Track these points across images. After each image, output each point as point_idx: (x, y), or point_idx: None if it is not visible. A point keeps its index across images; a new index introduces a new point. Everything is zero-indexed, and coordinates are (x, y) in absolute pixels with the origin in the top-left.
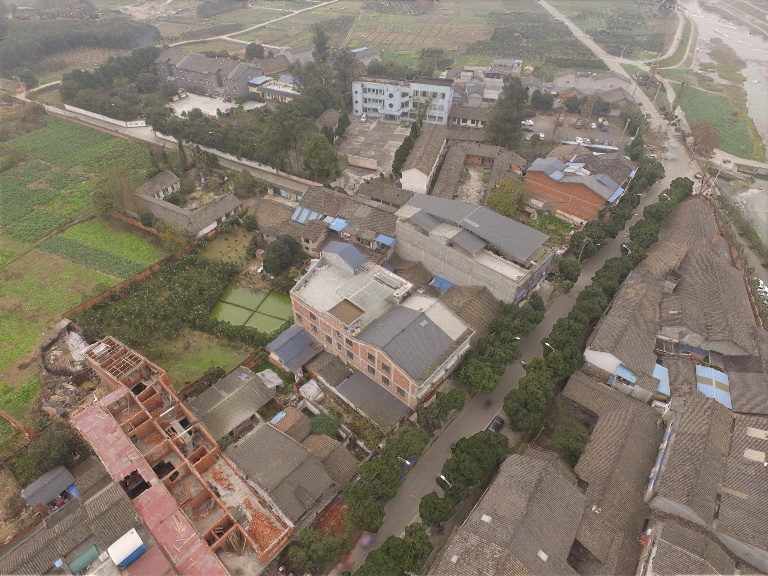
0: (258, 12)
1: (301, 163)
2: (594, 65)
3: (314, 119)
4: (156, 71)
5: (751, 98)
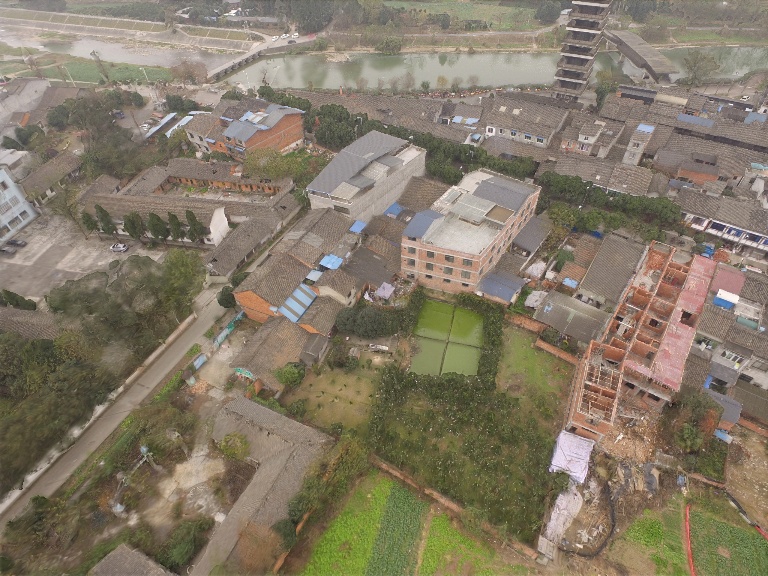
0: None
1: None
2: None
3: None
4: None
5: (78, 55)
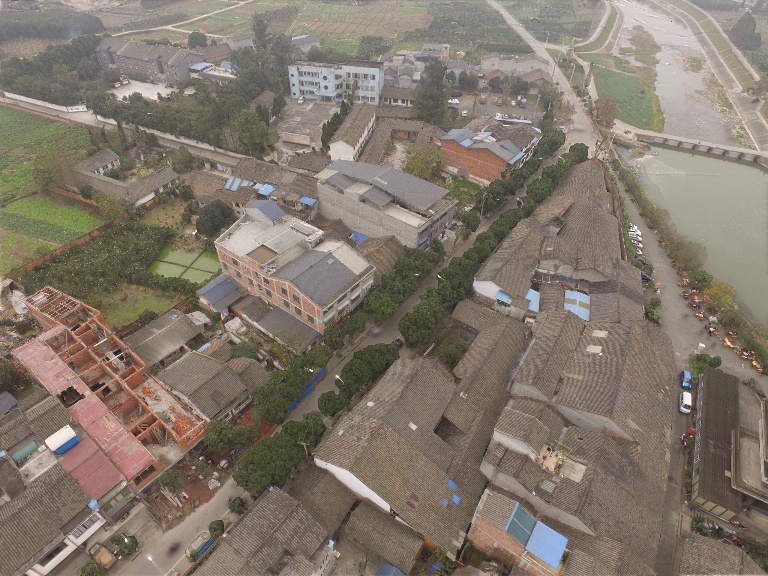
0: (204, 3)
1: (236, 139)
2: (521, 50)
3: (250, 100)
4: (97, 59)
5: (660, 78)
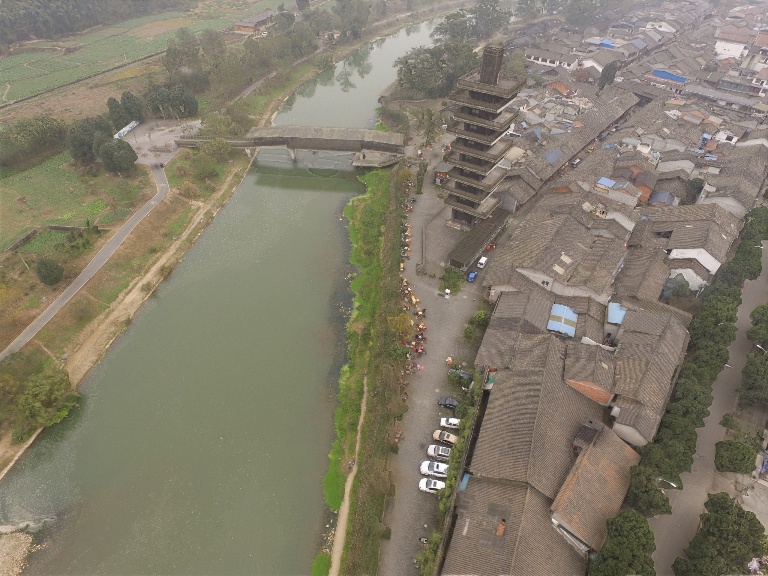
0: None
1: None
2: None
3: None
4: None
5: None
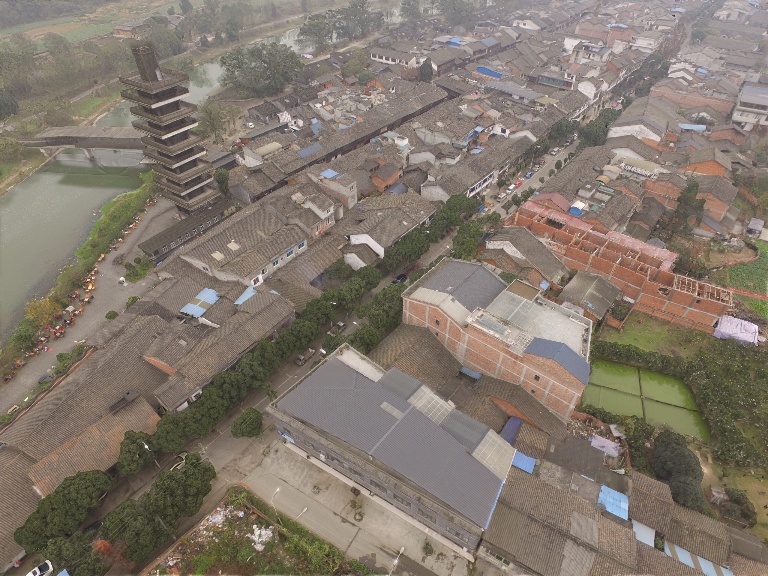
0: None
1: None
2: None
3: None
4: None
5: None
